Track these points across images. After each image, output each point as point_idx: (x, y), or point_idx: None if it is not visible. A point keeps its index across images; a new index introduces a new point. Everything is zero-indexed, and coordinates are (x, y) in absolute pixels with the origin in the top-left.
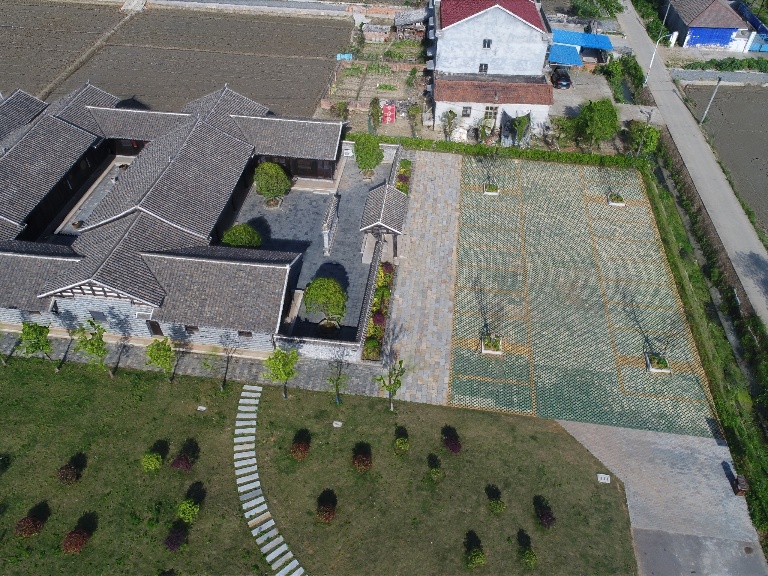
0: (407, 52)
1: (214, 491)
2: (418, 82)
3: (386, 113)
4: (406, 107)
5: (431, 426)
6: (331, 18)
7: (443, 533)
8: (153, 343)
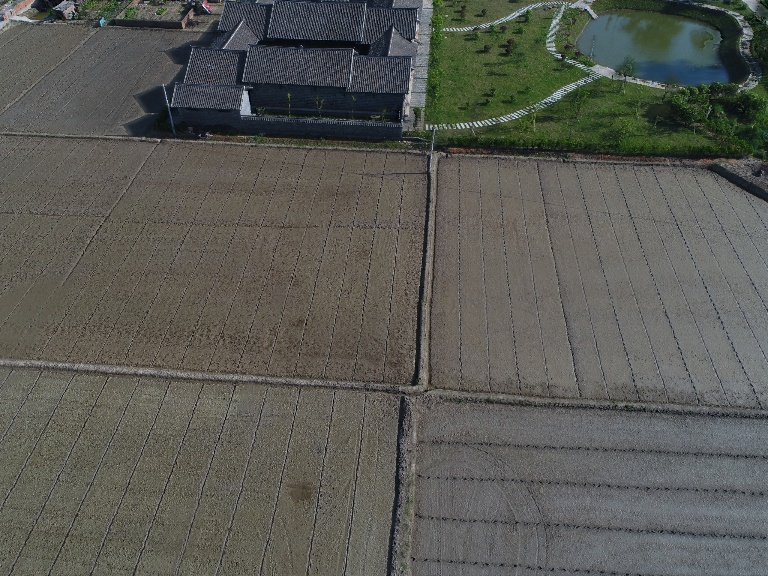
0: (103, 5)
1: (481, 31)
2: (160, 1)
3: (207, 6)
4: (202, 0)
5: (444, 2)
6: (3, 31)
7: (484, 0)
8: (436, 16)
